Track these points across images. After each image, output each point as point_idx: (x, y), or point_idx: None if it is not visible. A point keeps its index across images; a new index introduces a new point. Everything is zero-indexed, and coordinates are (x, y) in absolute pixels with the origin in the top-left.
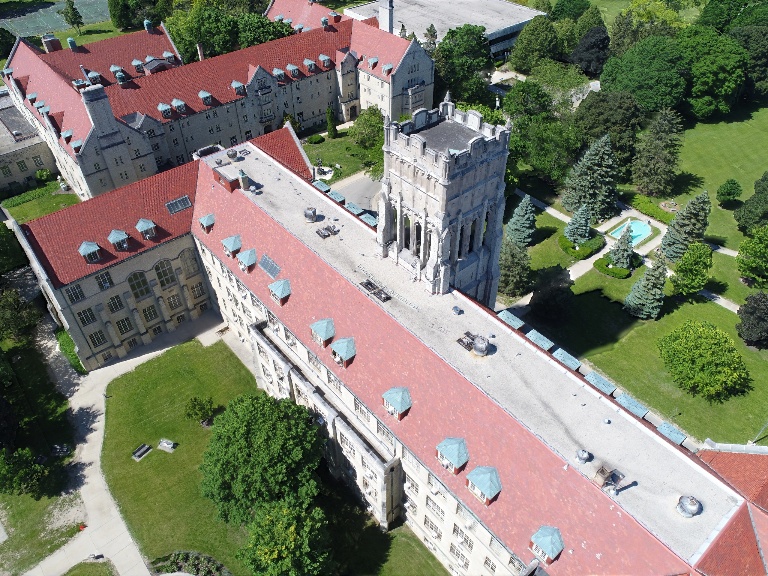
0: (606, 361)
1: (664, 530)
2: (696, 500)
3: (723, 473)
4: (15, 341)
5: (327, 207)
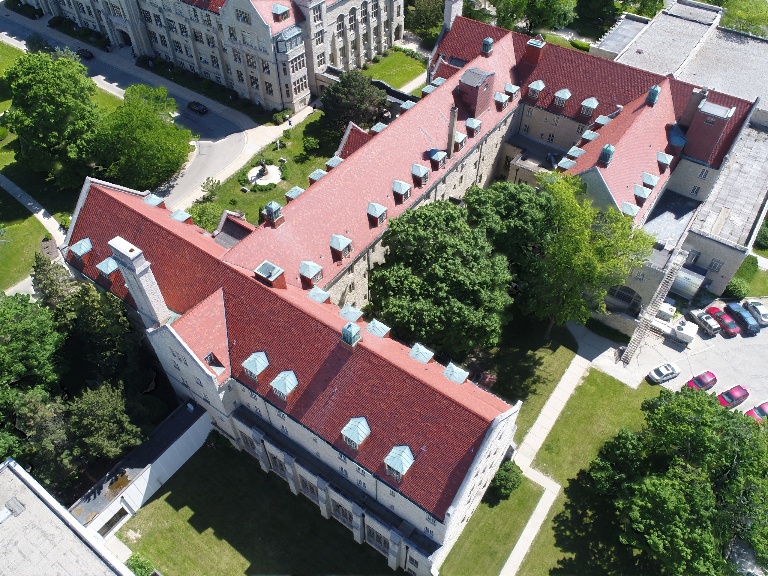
0: None
1: None
2: None
3: None
4: (423, 31)
5: None
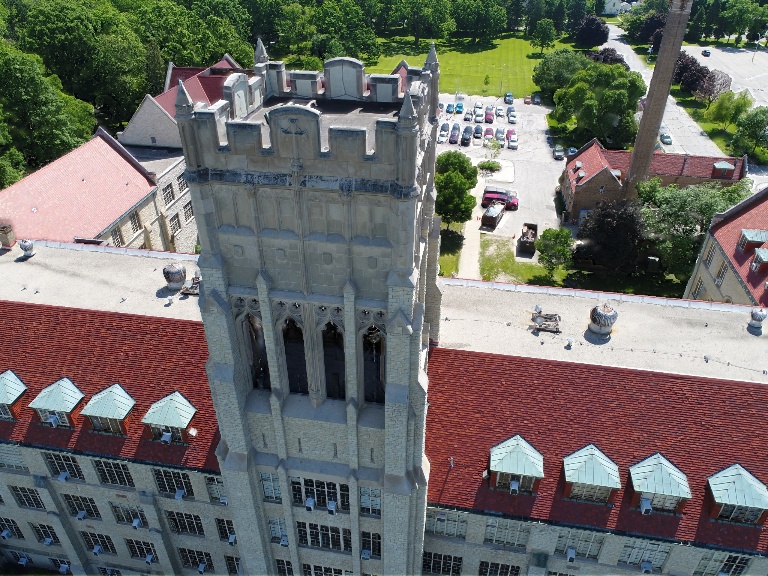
0: None
1: None
2: None
3: None
4: None
5: (621, 359)
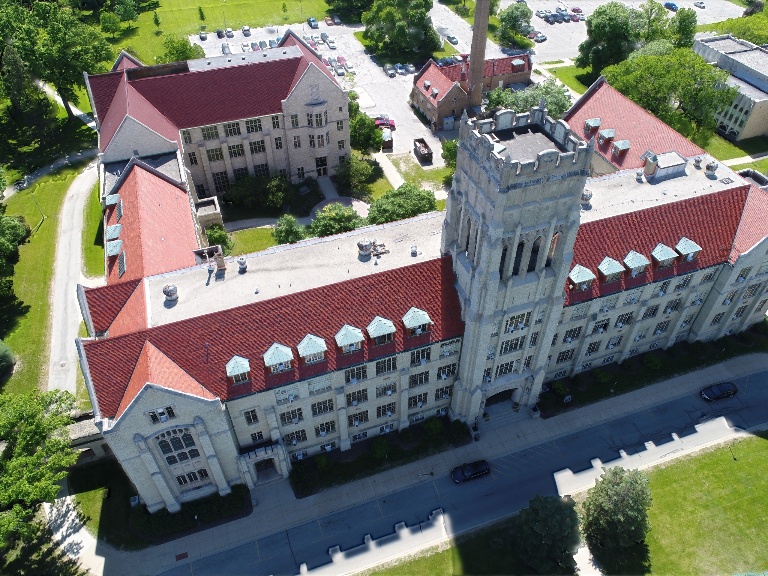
0: (439, 572)
1: (172, 281)
2: (167, 289)
3: (184, 373)
4: None
5: (604, 214)
